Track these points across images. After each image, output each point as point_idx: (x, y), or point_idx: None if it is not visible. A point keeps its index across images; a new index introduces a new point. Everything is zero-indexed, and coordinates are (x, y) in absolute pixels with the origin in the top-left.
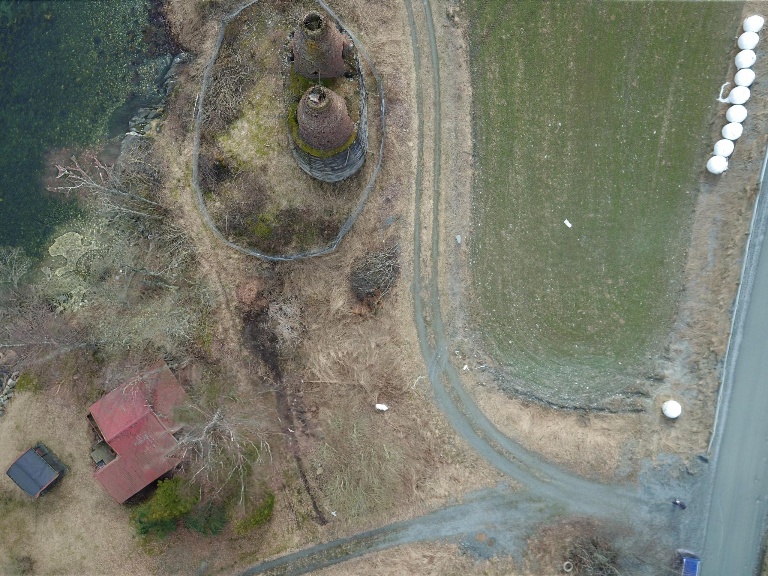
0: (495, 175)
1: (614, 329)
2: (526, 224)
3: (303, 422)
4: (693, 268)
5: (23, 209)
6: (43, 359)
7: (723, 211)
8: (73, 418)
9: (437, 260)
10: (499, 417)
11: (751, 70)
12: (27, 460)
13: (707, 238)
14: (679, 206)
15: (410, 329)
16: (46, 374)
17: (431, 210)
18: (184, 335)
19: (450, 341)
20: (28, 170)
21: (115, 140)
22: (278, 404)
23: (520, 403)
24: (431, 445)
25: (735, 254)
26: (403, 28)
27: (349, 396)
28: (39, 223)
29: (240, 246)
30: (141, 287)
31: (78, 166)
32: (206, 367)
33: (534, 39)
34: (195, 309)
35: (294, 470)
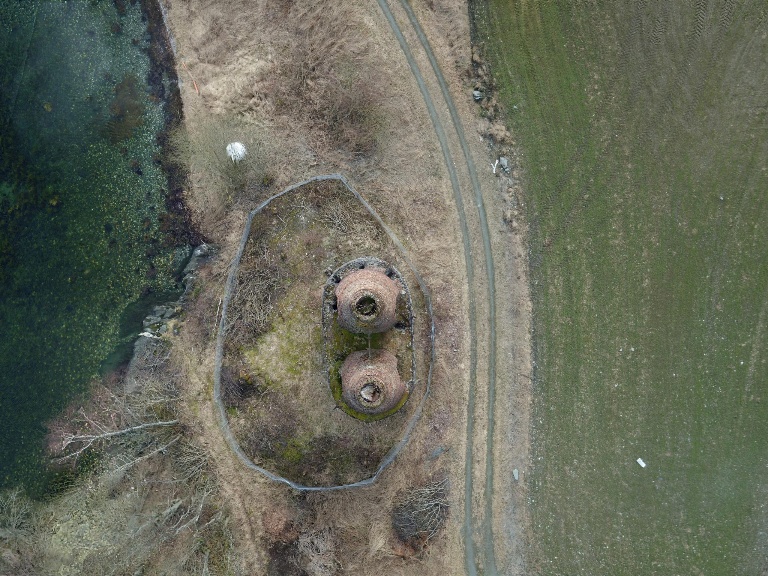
0: (558, 403)
1: None
2: (593, 461)
3: None
4: None
5: (24, 415)
6: None
7: None
8: None
9: (491, 499)
10: None
11: None
12: None
13: None
14: None
15: None
16: None
17: (485, 441)
18: None
19: None
20: (30, 372)
21: (127, 340)
22: None
23: None
24: None
25: None
26: (454, 234)
27: None
28: (41, 432)
29: (267, 469)
30: None
31: (86, 416)
32: None
33: (603, 251)
34: (216, 543)
35: None
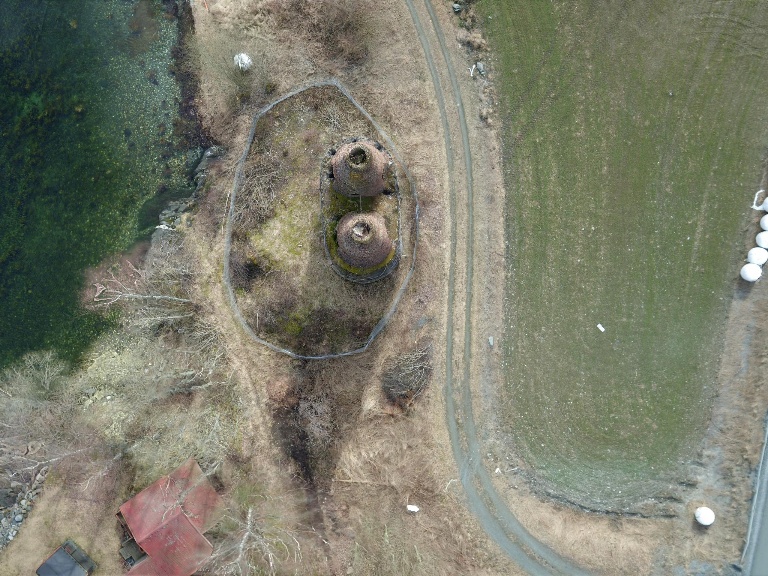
0: (528, 277)
1: (647, 434)
2: (559, 327)
3: (333, 521)
4: (726, 374)
5: (52, 301)
6: None
7: (757, 318)
8: (102, 514)
9: (469, 362)
10: (531, 521)
11: None
12: (57, 559)
13: (740, 344)
14: (712, 312)
15: (442, 431)
16: (75, 469)
17: (464, 312)
18: None
19: (482, 443)
20: (57, 262)
21: (145, 233)
22: (308, 502)
23: (552, 506)
24: (463, 548)
25: None
26: (436, 129)
27: (380, 496)
28: (68, 315)
29: (271, 343)
30: (171, 383)
31: (114, 277)
32: (236, 465)
33: (568, 143)
34: (226, 407)
35: (324, 569)
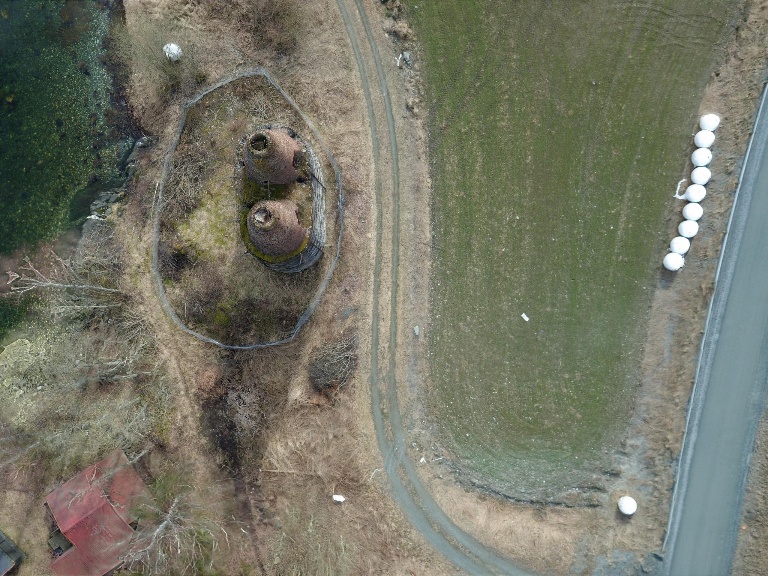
0: (453, 267)
1: (571, 423)
2: (484, 317)
3: (261, 511)
4: (649, 364)
5: None
6: (1, 445)
7: (679, 307)
8: (31, 504)
9: (395, 352)
10: (455, 511)
11: (707, 169)
12: None
13: (663, 334)
14: (636, 301)
15: (367, 421)
16: (4, 460)
17: (389, 302)
18: (137, 433)
19: (407, 433)
20: None
21: (76, 223)
22: (236, 492)
23: (477, 496)
24: (387, 538)
25: (690, 352)
26: (362, 119)
27: (307, 486)
28: None
29: (199, 333)
30: None
31: (31, 266)
32: (164, 455)
33: (492, 132)
34: (153, 397)
35: (252, 559)
